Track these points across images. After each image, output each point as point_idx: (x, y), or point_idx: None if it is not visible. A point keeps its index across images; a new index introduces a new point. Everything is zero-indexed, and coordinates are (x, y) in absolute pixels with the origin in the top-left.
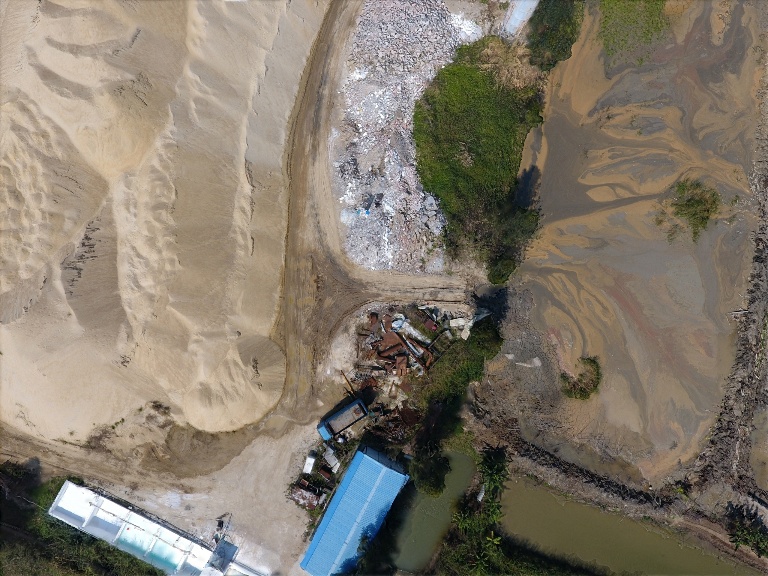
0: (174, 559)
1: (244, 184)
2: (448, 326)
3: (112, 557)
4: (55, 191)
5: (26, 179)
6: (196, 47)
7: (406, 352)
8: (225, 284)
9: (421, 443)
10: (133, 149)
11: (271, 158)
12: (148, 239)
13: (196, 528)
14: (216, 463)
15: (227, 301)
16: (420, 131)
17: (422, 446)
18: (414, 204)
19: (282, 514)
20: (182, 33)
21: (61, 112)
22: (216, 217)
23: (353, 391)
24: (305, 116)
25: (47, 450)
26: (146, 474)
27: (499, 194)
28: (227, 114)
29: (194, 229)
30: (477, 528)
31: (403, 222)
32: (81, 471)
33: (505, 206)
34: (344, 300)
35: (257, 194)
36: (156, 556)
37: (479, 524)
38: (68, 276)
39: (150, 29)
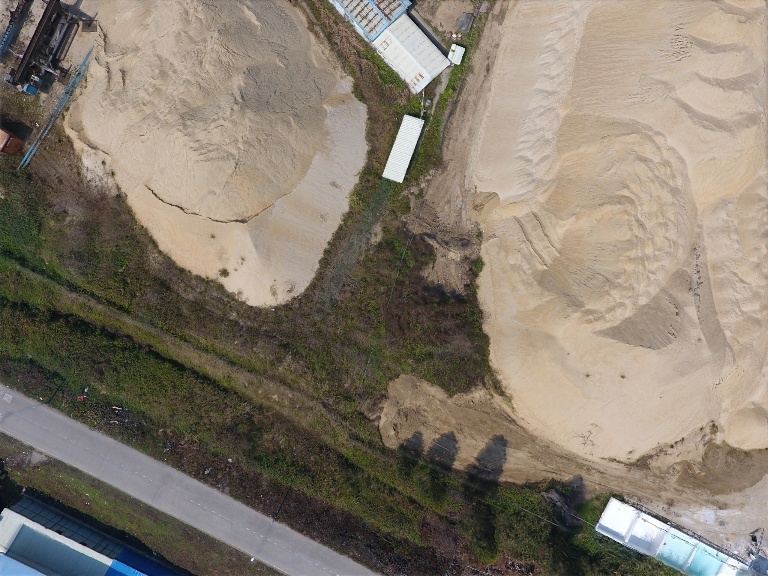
0: (708, 573)
1: None
2: None
3: (662, 572)
4: (678, 219)
5: (649, 208)
6: None
7: None
8: None
9: None
10: (741, 178)
11: None
12: (756, 265)
13: (730, 543)
14: (749, 480)
15: None
16: None
17: None
18: None
19: None
20: None
21: (693, 143)
22: None
23: None
24: None
25: (590, 468)
26: (682, 491)
27: None
28: None
29: None
30: None
31: None
32: (621, 488)
33: None
34: None
35: None
36: (692, 570)
37: None
38: (696, 302)
39: (767, 62)
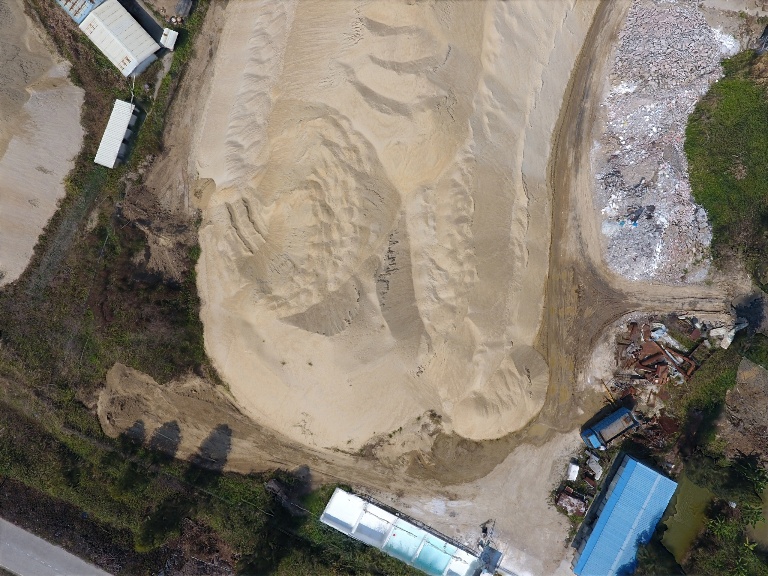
0: (439, 565)
1: (520, 196)
2: (706, 335)
3: (385, 563)
4: (365, 205)
5: (336, 193)
6: (490, 63)
7: (665, 361)
8: (506, 295)
9: (685, 451)
10: (435, 163)
11: (538, 170)
12: (450, 252)
13: (460, 534)
14: (480, 470)
15: (506, 312)
16: (694, 144)
17: (687, 454)
18: (687, 216)
19: (544, 520)
20: (479, 49)
21: (375, 128)
22: (499, 229)
23: (613, 399)
24: (568, 129)
25: (317, 458)
26: (412, 481)
27: (762, 206)
28: (510, 128)
29: (485, 241)
30: (731, 534)
31: (677, 234)
32: (349, 478)
33: (766, 217)
34: (604, 310)
35: (531, 206)
36: (422, 562)
37: (732, 530)
38: (381, 288)
39: (457, 46)
